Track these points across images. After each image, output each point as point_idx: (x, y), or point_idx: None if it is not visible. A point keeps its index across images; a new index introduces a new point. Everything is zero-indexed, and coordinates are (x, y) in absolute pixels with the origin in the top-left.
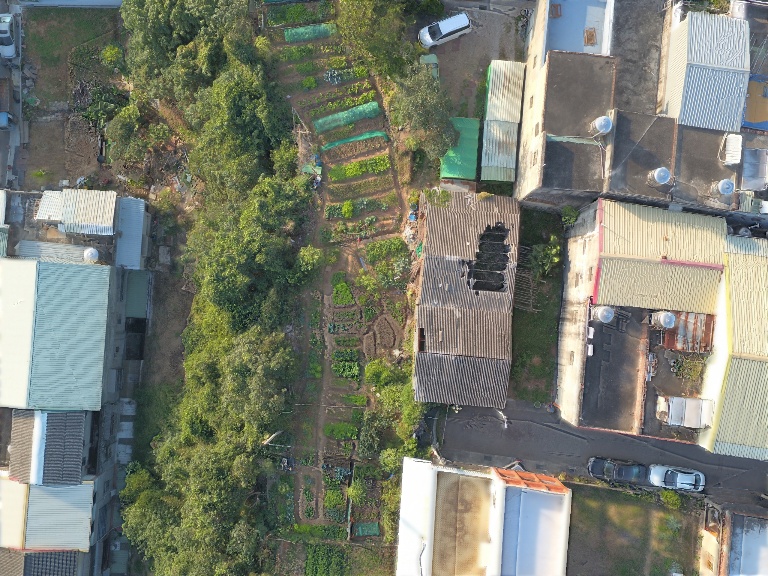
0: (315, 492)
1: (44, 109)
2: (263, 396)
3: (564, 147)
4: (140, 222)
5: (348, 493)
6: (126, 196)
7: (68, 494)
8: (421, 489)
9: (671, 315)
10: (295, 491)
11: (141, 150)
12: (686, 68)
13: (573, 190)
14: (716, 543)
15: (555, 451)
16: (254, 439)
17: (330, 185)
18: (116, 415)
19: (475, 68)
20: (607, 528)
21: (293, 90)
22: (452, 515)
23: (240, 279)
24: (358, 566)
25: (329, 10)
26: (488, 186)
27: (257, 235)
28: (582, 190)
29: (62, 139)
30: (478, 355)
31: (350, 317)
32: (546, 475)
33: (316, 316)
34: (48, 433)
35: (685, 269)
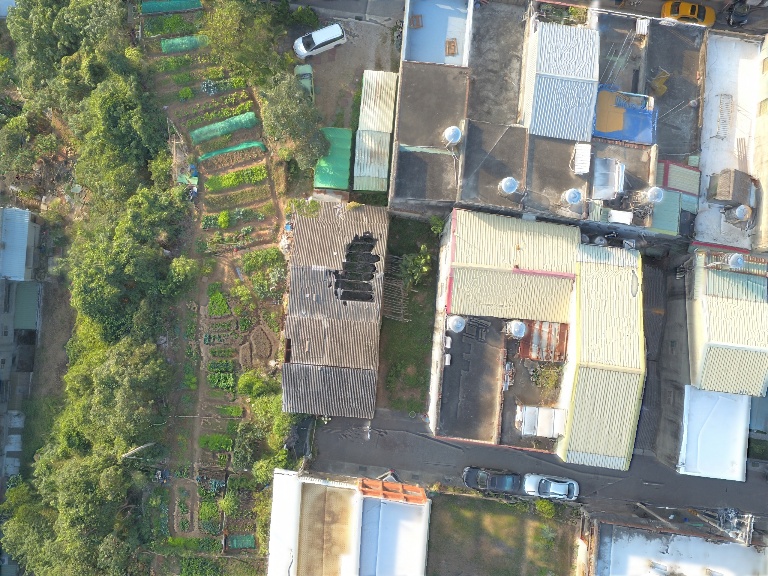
0: (190, 504)
1: None
2: (128, 408)
3: (417, 157)
4: (25, 233)
5: (220, 505)
6: (19, 207)
7: None
8: None
9: (521, 324)
10: (170, 504)
11: (28, 161)
12: (535, 78)
13: (427, 200)
14: (586, 552)
15: (430, 461)
16: (123, 451)
17: (207, 195)
18: (2, 428)
19: (351, 78)
20: (483, 538)
21: (170, 100)
22: (319, 527)
23: (107, 290)
24: None
25: (207, 21)
26: (363, 196)
27: (126, 246)
28: (436, 200)
29: None
30: (344, 365)
31: (226, 328)
32: (421, 485)
33: (192, 327)
34: None
35: (535, 278)
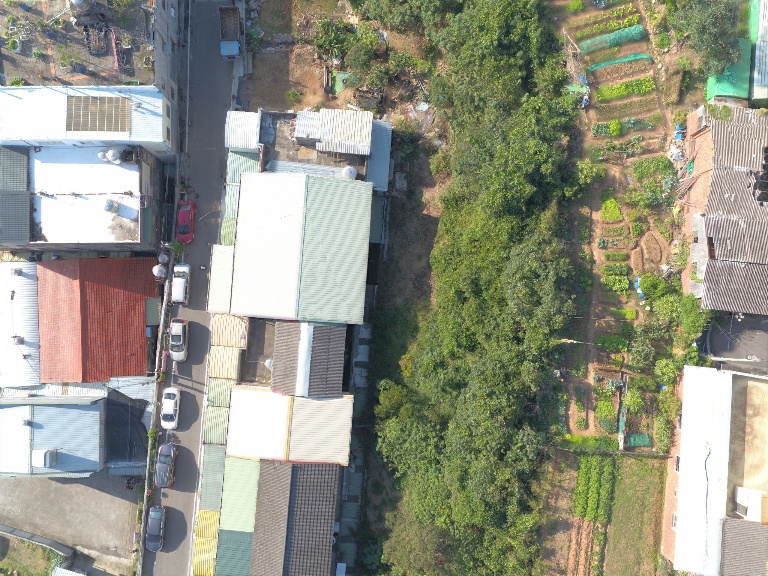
0: (586, 403)
1: (268, 41)
2: (558, 300)
3: None
4: (388, 145)
5: (625, 402)
6: None
7: (330, 407)
8: (707, 395)
9: None
10: (566, 402)
11: (383, 76)
12: None
13: None
14: None
15: None
16: (538, 346)
17: (597, 104)
18: None
19: None
20: None
21: (560, 12)
22: (741, 419)
23: (529, 188)
24: (629, 476)
25: None
26: (754, 107)
27: (543, 146)
28: None
29: (287, 70)
30: (767, 263)
31: (619, 232)
32: None
33: (585, 231)
34: (314, 345)
35: None
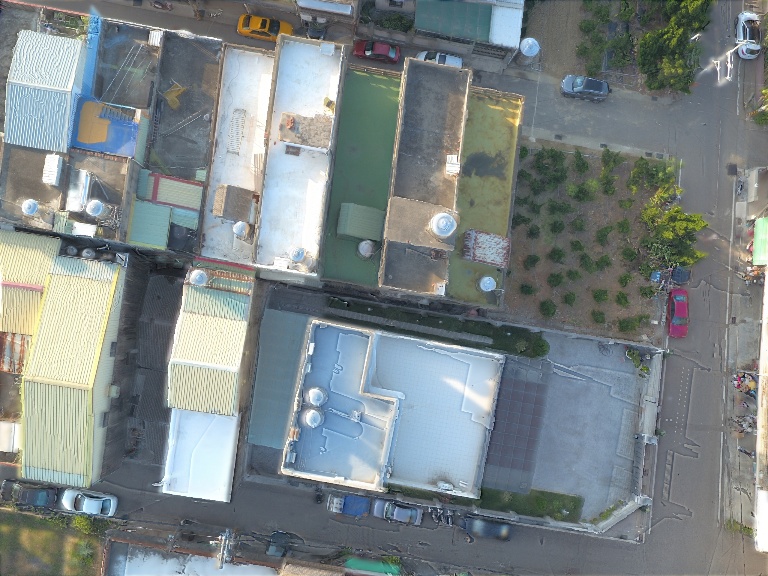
0: None
1: None
2: None
3: None
4: None
5: None
6: None
7: None
8: None
9: None
10: None
11: None
12: (7, 86)
13: None
14: None
15: None
16: None
17: None
18: None
19: None
20: (20, 553)
21: None
22: None
23: None
24: None
25: None
26: None
27: None
28: None
29: None
30: None
31: None
32: None
33: None
34: None
35: None
